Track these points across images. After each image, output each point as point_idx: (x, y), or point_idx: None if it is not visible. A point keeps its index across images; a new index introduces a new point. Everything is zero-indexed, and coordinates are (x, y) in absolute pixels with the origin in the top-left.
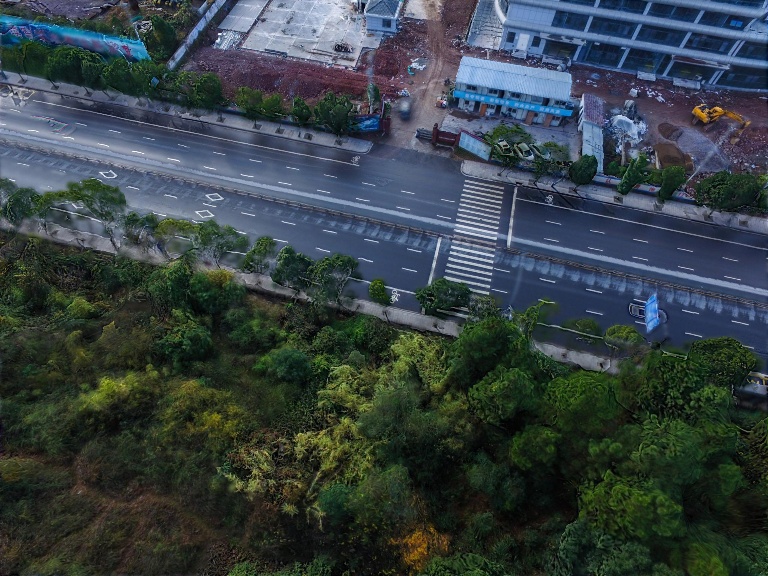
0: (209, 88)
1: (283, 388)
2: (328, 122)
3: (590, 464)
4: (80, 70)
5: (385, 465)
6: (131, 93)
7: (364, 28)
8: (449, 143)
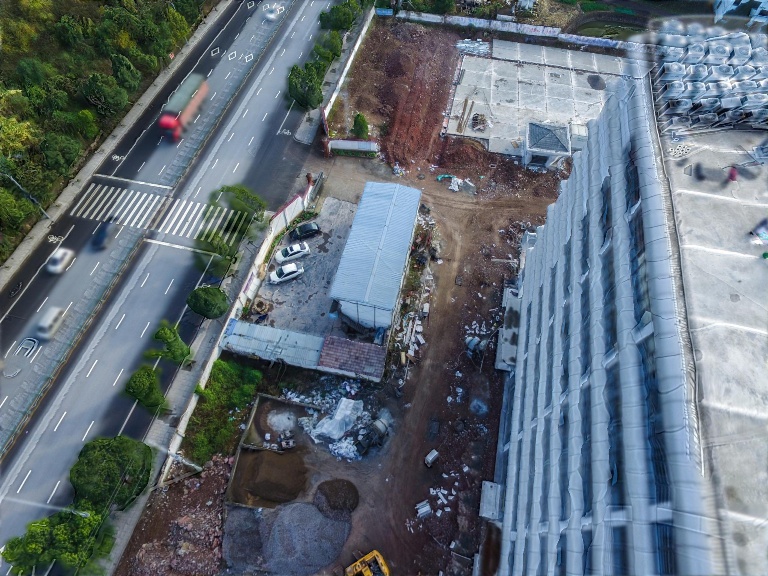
0: None
1: None
2: None
3: None
4: None
5: None
6: None
7: None
8: None
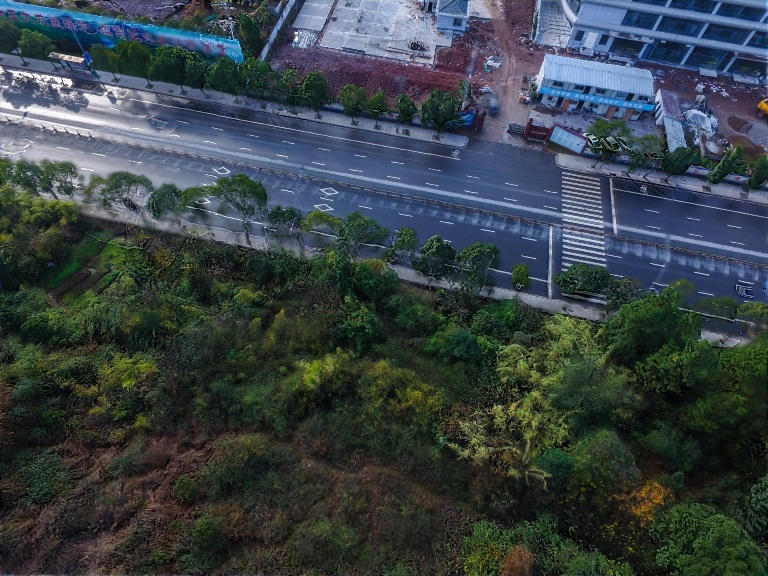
0: (317, 86)
1: (461, 367)
2: (435, 118)
3: None
4: (184, 69)
5: (576, 433)
6: (230, 91)
7: (434, 27)
8: (540, 137)
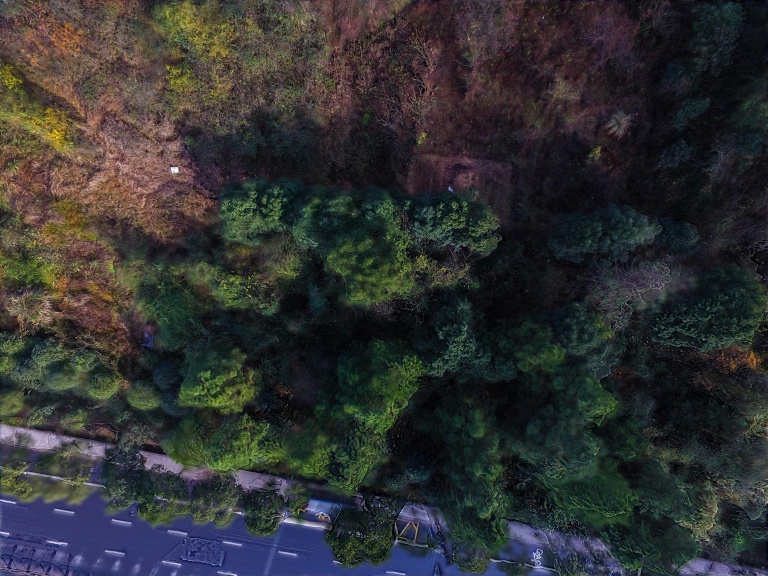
0: None
1: None
2: None
3: None
4: None
5: (731, 411)
6: None
7: None
8: None
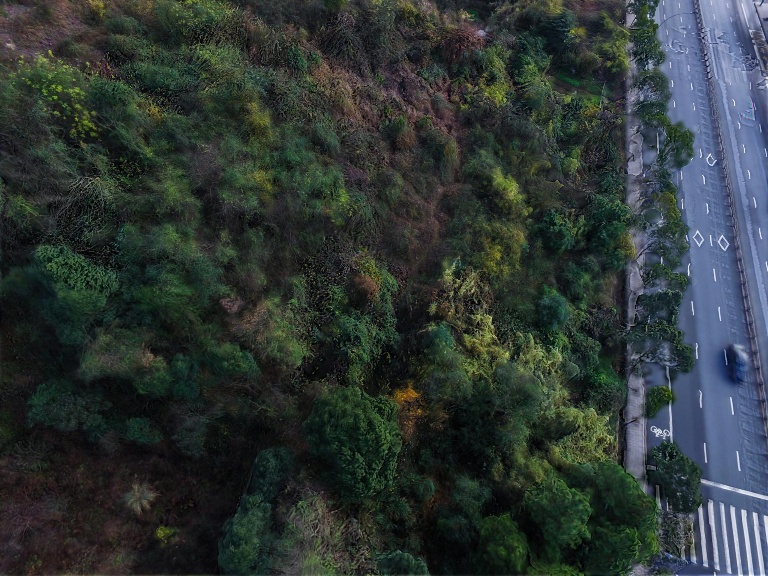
0: None
1: (530, 307)
2: None
3: None
4: None
5: None
6: None
7: None
8: None
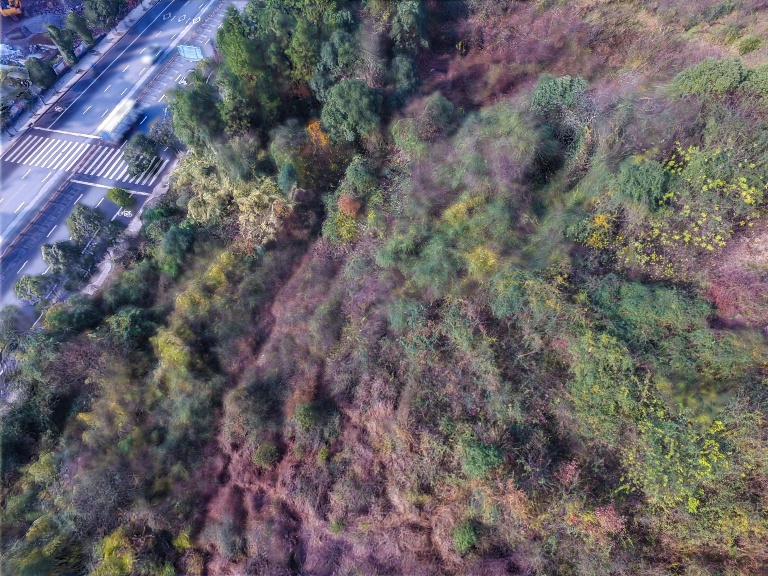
0: None
1: (199, 245)
2: None
3: (282, 72)
4: None
5: None
6: None
7: None
8: None
